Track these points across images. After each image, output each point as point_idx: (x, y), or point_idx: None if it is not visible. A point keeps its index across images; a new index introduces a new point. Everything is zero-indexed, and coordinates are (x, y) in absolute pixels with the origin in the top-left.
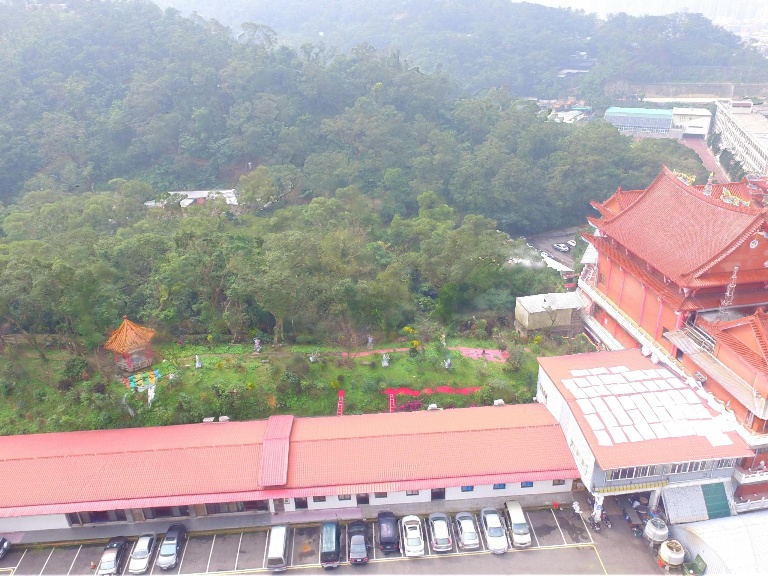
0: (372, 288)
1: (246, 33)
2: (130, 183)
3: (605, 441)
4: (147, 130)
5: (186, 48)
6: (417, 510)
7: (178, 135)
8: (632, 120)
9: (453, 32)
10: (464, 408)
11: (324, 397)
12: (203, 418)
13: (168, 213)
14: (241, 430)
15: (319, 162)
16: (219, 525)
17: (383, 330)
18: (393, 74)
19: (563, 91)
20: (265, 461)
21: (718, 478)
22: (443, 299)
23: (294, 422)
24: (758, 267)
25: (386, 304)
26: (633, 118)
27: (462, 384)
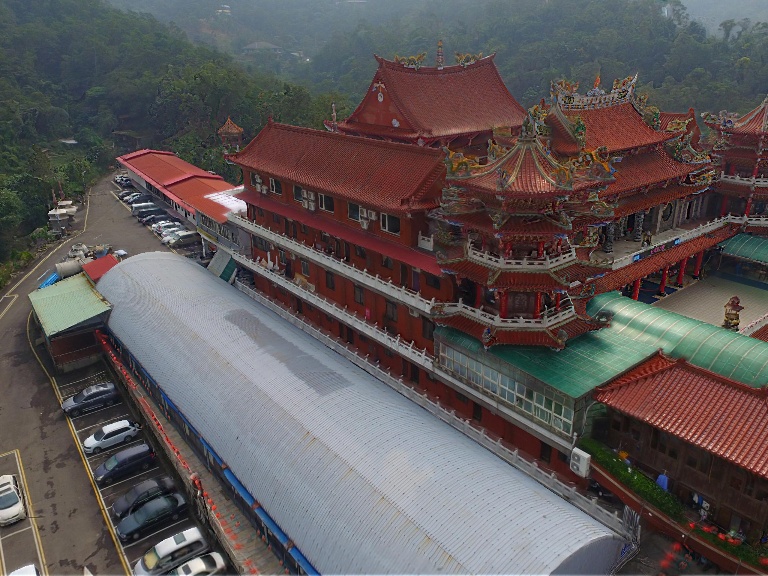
0: None
1: (654, 8)
2: None
3: None
4: None
5: (581, 19)
6: None
7: None
8: None
9: None
10: None
11: None
12: None
13: None
14: None
15: None
16: None
17: None
18: None
19: None
20: None
21: None
22: None
23: None
24: (388, 124)
25: None
26: None
27: None
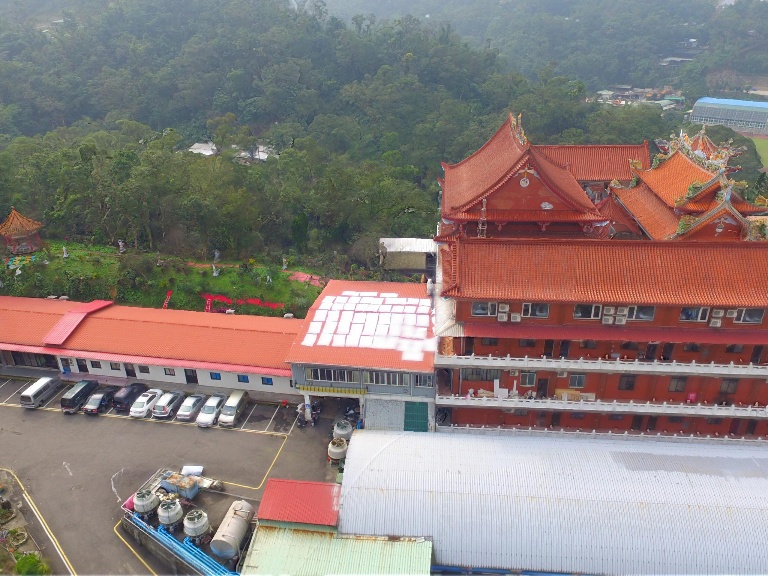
0: (225, 209)
1: (297, 3)
2: (129, 123)
3: (308, 342)
4: (188, 86)
5: (236, 15)
6: (170, 388)
7: (214, 93)
8: (724, 112)
9: (550, 14)
10: (255, 316)
11: (155, 294)
12: (50, 295)
13: (146, 149)
14: (66, 306)
15: (322, 122)
16: (18, 373)
17: (233, 248)
18: (432, 46)
19: (662, 80)
20: (57, 326)
21: (420, 397)
22: (291, 227)
23: (111, 306)
24: (534, 208)
25: (234, 224)
26: (725, 110)
27: (274, 299)
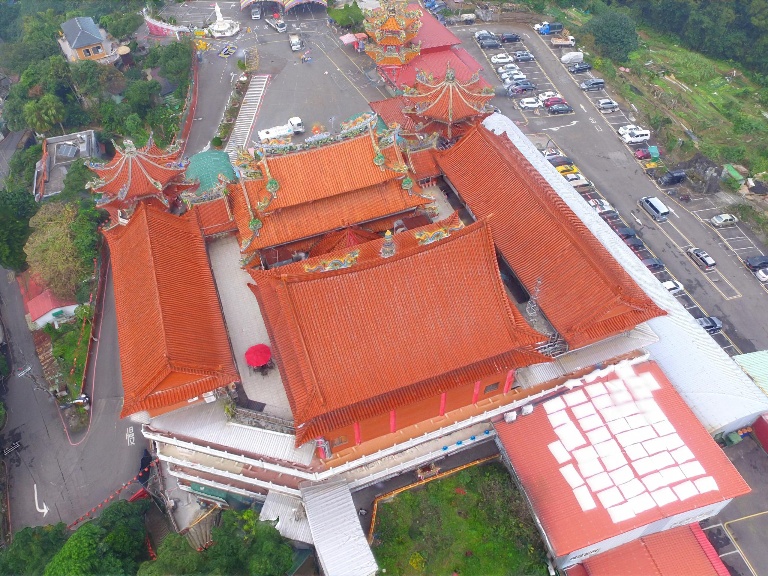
0: None
1: None
2: None
3: (712, 483)
4: None
5: None
6: None
7: None
8: None
9: None
10: None
11: None
12: None
13: None
14: None
15: None
16: None
17: None
18: None
19: None
20: None
21: None
22: None
23: None
24: None
25: None
26: None
27: None
